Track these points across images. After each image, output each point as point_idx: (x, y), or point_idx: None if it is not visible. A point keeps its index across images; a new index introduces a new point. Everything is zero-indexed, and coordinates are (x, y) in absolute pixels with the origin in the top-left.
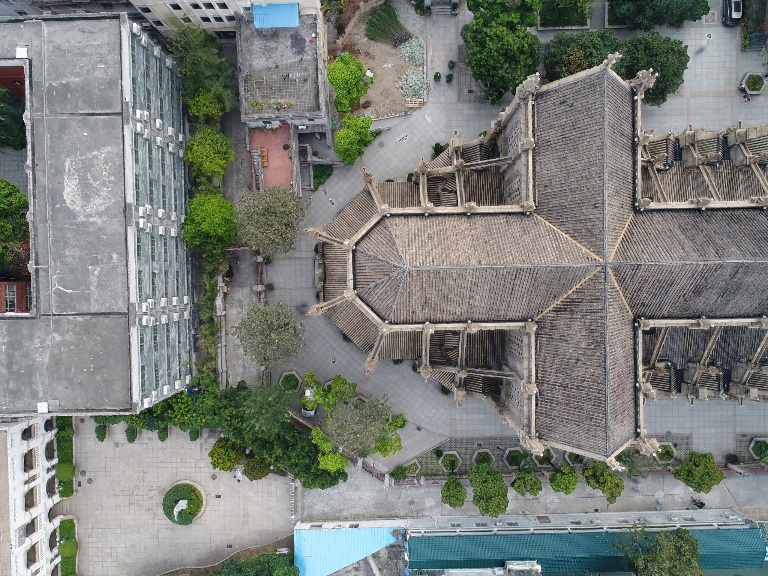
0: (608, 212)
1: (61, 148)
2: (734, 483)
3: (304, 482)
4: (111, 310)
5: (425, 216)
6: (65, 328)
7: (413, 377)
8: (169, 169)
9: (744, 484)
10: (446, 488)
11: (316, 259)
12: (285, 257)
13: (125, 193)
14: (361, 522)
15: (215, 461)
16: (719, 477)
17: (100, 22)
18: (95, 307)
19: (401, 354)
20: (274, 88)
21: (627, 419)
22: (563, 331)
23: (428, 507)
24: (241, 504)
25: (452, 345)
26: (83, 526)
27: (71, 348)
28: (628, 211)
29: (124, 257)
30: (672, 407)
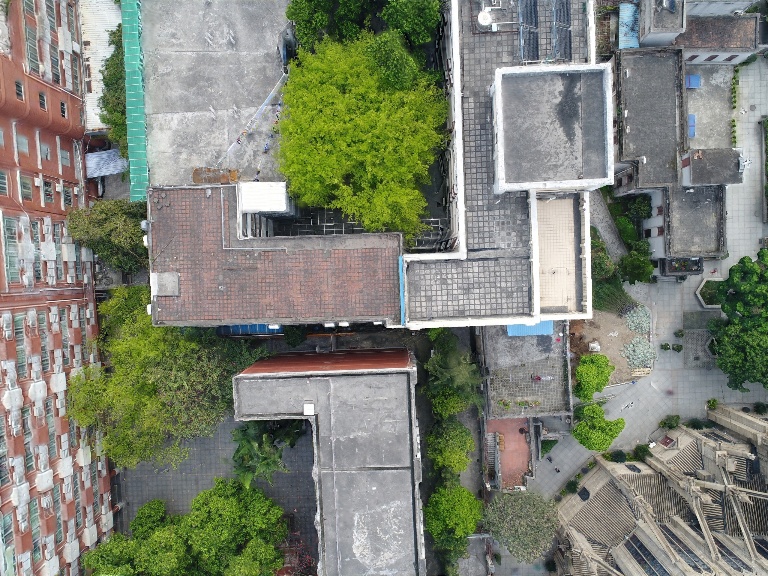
0: None
1: (349, 502)
2: None
3: None
4: None
5: None
6: None
7: None
8: None
9: None
10: None
11: None
12: None
13: (418, 549)
14: None
15: None
16: None
17: (387, 377)
18: None
19: None
20: (520, 386)
21: None
22: None
23: None
24: None
25: None
26: None
27: None
28: None
29: None
30: None
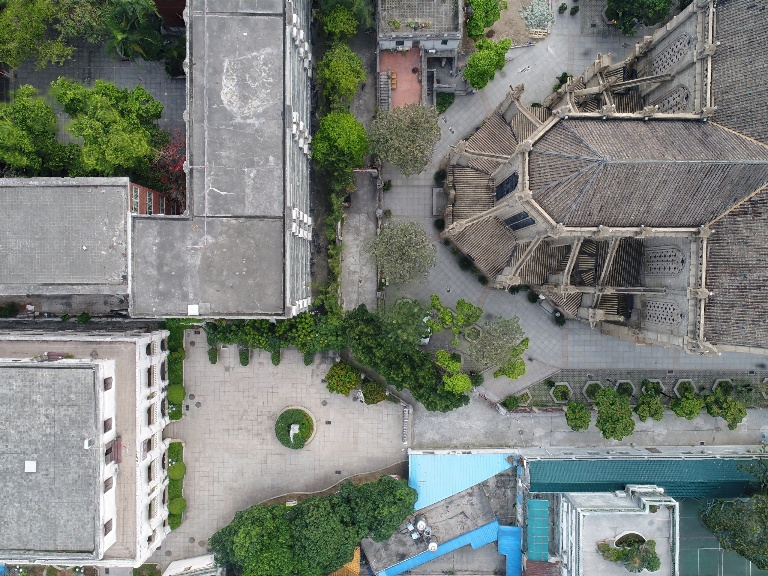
0: None
1: (220, 48)
2: None
3: (427, 404)
4: (266, 213)
5: (601, 120)
6: (218, 230)
7: (527, 308)
8: (303, 85)
9: None
10: (571, 411)
11: (434, 187)
12: (403, 185)
13: (285, 95)
14: (472, 450)
15: (334, 383)
16: None
17: None
18: (250, 210)
19: (528, 279)
20: (411, 7)
21: None
22: (742, 234)
23: (537, 437)
24: (351, 431)
25: (587, 267)
26: (190, 450)
27: (224, 251)
28: None
29: (281, 160)
30: None
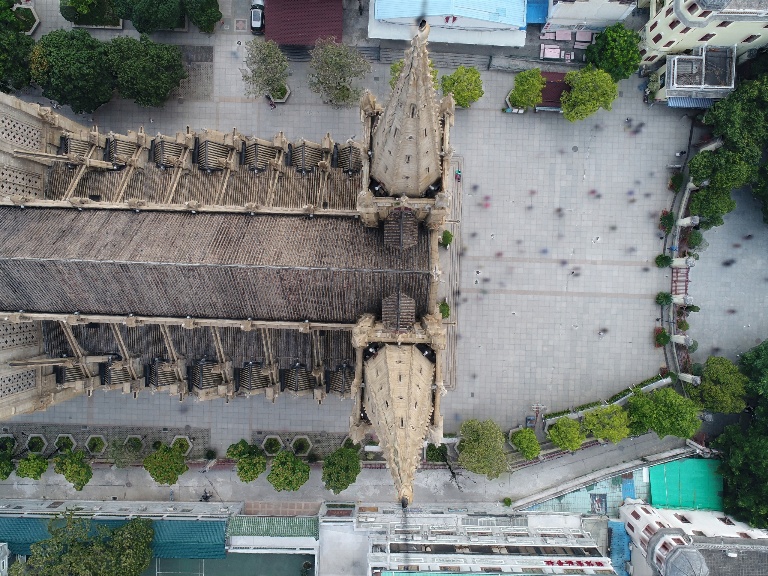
0: None
1: None
2: None
3: None
4: None
5: None
6: None
7: None
8: None
9: (255, 479)
10: None
11: None
12: None
13: None
14: None
15: None
16: (173, 469)
17: None
18: None
19: None
20: None
21: None
22: None
23: None
24: None
25: None
26: None
27: None
28: None
29: None
30: (192, 402)
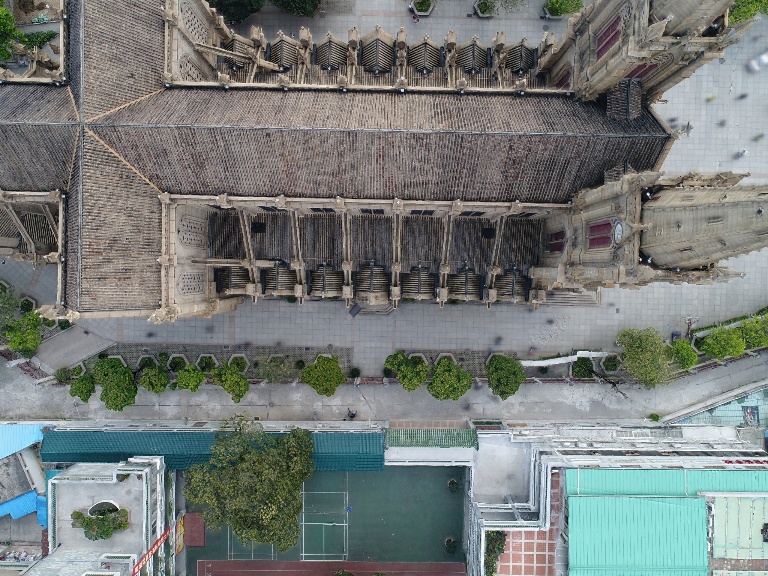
0: (87, 73)
1: None
2: (390, 396)
3: None
4: None
5: None
6: None
7: None
8: None
9: (399, 398)
10: (74, 381)
11: None
12: None
13: None
14: (23, 421)
15: None
16: (335, 379)
17: None
18: None
19: None
20: None
21: (139, 288)
22: None
23: (93, 410)
24: None
25: None
26: None
27: None
28: (151, 85)
29: None
30: (334, 321)
